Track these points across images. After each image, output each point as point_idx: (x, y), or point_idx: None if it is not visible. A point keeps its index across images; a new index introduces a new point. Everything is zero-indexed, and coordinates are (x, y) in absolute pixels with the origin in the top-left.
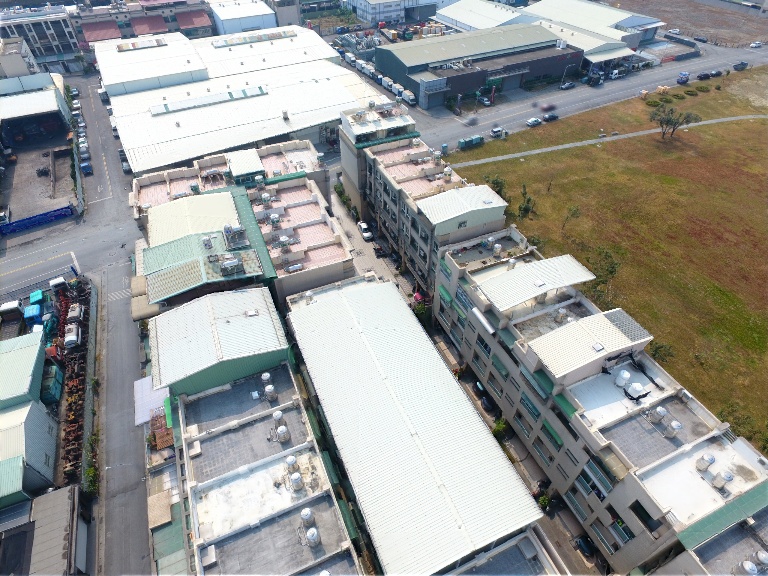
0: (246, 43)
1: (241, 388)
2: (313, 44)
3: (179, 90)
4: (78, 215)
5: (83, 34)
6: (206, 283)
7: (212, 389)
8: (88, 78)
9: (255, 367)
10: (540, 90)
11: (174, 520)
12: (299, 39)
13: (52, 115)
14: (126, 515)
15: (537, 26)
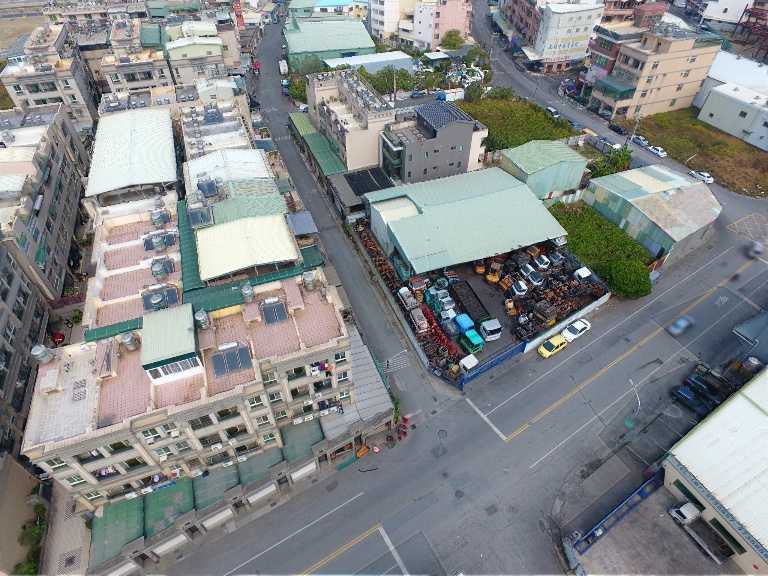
0: None
1: None
2: None
3: None
4: None
5: None
6: None
7: None
8: None
9: None
10: None
11: None
12: None
13: None
14: (323, 220)
15: None
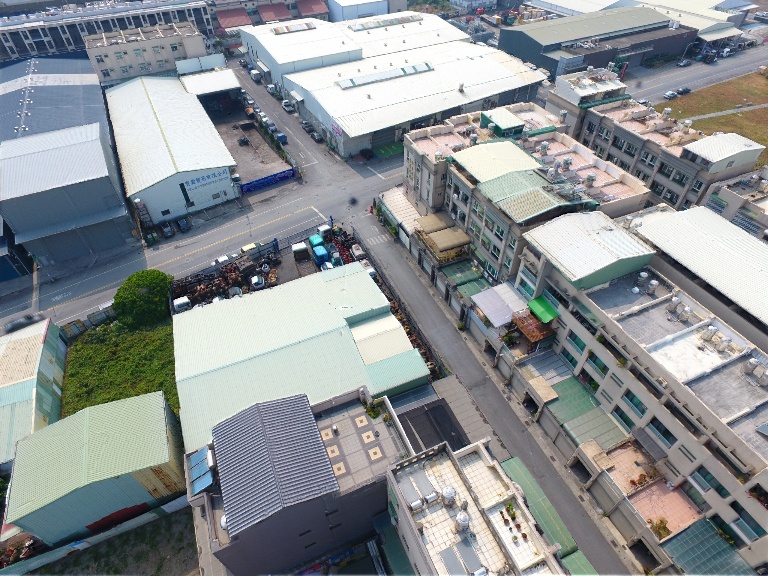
0: (380, 27)
1: (617, 286)
2: (441, 27)
3: (345, 68)
4: (298, 177)
5: (218, 21)
6: (559, 206)
7: (598, 286)
8: (228, 62)
9: (628, 269)
10: (660, 67)
11: (559, 397)
12: (426, 23)
13: (222, 93)
14: (490, 402)
15: (646, 8)
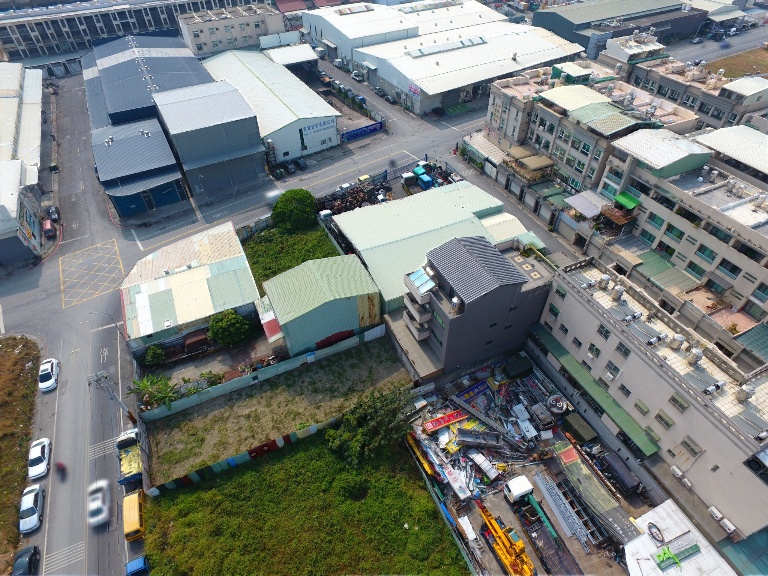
0: (427, 10)
1: (685, 178)
2: (481, 10)
3: (407, 43)
4: (385, 129)
5: (277, 6)
6: (636, 123)
7: (672, 177)
8: None
9: (693, 165)
10: (676, 44)
11: (643, 262)
12: (467, 6)
13: None
14: None
15: None
